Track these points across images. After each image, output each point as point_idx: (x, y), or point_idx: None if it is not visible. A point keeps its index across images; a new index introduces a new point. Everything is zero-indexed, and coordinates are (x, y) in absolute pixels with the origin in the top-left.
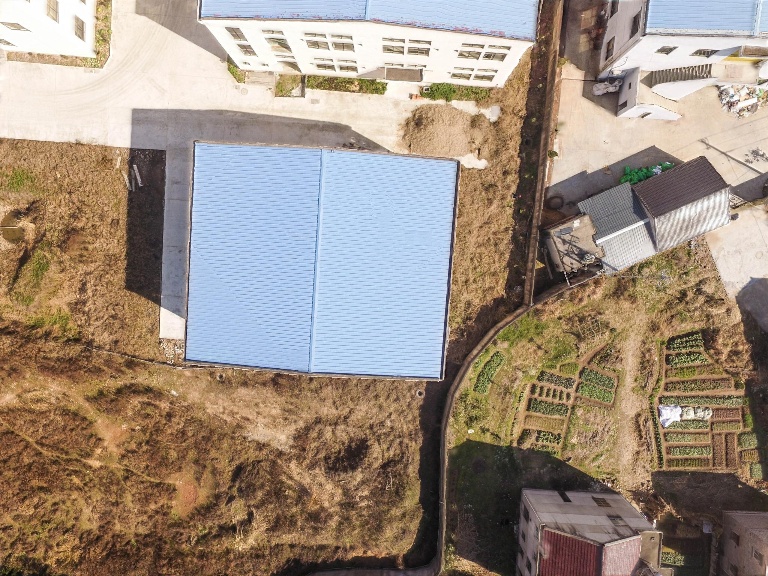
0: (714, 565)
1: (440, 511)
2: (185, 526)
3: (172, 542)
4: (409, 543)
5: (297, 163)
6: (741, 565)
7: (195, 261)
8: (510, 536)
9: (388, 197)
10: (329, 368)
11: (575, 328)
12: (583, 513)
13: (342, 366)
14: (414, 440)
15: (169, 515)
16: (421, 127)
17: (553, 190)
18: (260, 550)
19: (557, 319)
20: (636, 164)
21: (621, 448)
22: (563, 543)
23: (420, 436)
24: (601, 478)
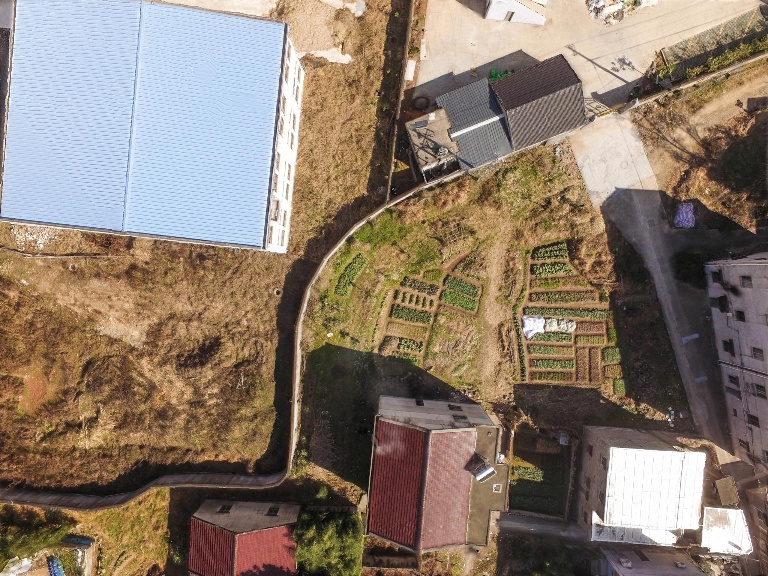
0: (572, 480)
1: None
2: (30, 421)
3: (16, 437)
4: (263, 448)
5: (117, 15)
6: (593, 475)
7: (13, 115)
8: (367, 445)
9: (206, 51)
10: (144, 228)
11: (439, 233)
12: (429, 412)
13: (158, 227)
14: (270, 340)
15: (15, 410)
16: (282, 16)
17: (419, 90)
18: (108, 450)
19: (421, 223)
20: (502, 67)
21: (484, 359)
22: (395, 433)
23: (276, 336)
24: (463, 389)
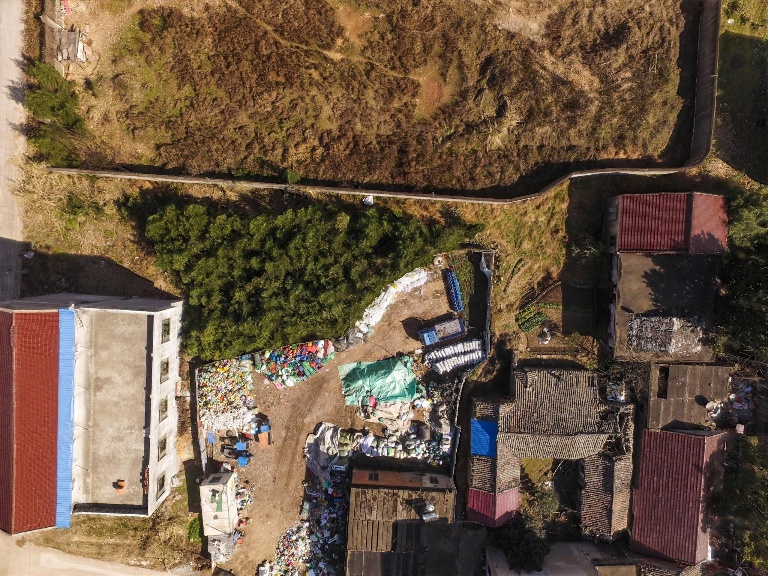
0: None
1: (701, 101)
2: (432, 122)
3: (418, 139)
4: (664, 142)
5: None
6: None
7: None
8: None
9: None
10: None
11: None
12: None
13: None
14: (675, 24)
15: (413, 113)
16: None
17: None
18: (508, 151)
19: None
20: None
21: None
22: None
23: (682, 19)
24: None
